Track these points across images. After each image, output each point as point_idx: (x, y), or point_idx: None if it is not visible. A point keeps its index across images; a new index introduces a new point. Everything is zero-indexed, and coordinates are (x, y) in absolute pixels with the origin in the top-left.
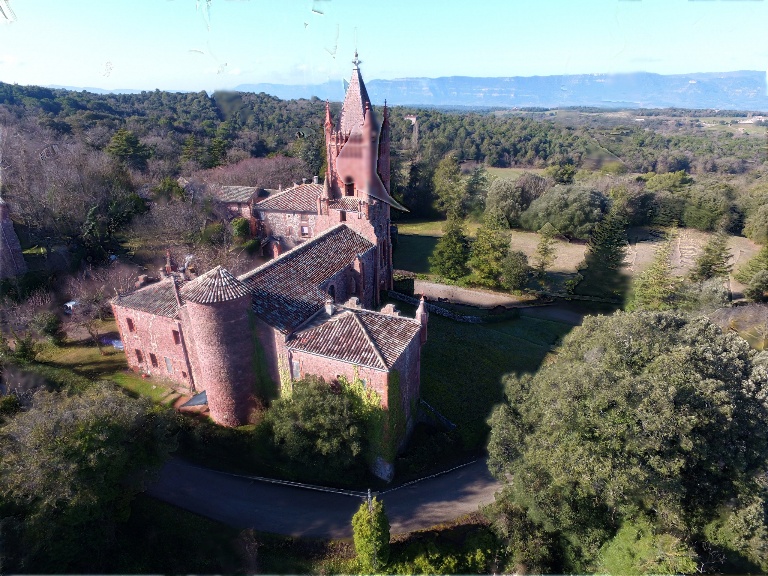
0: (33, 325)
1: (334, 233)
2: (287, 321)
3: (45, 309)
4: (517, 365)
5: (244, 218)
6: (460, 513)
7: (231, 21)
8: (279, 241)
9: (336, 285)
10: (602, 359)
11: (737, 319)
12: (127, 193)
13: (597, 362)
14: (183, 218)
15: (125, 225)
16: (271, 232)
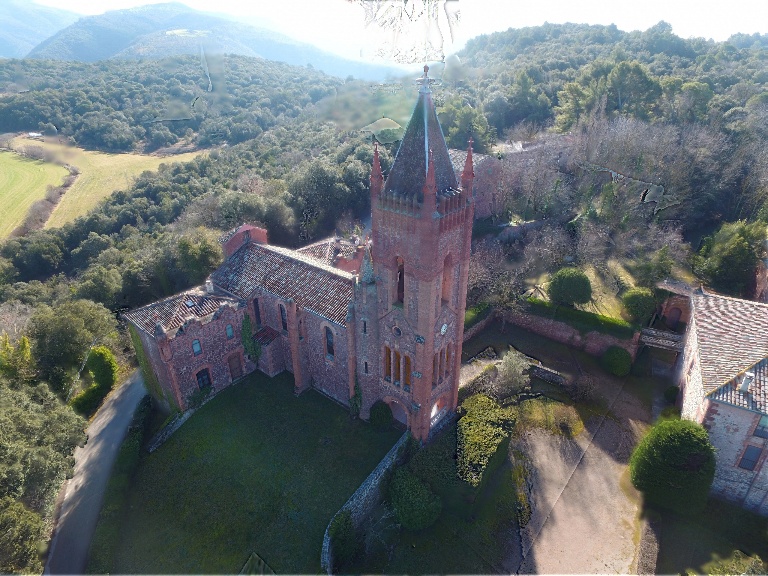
0: None
1: None
2: (218, 277)
3: None
4: None
5: (645, 292)
6: (88, 433)
7: None
8: (683, 360)
9: None
10: None
11: None
12: (640, 211)
13: None
14: (562, 245)
15: None
16: (687, 341)
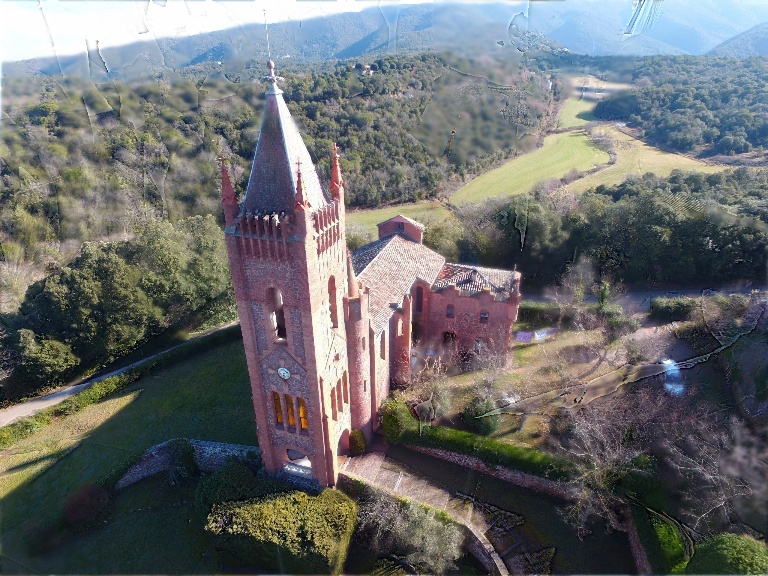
0: (620, 316)
1: None
2: None
3: (711, 375)
4: (156, 397)
5: None
6: None
7: (493, 3)
8: None
9: None
10: (188, 234)
11: None
12: None
13: (190, 236)
14: None
15: None
16: None
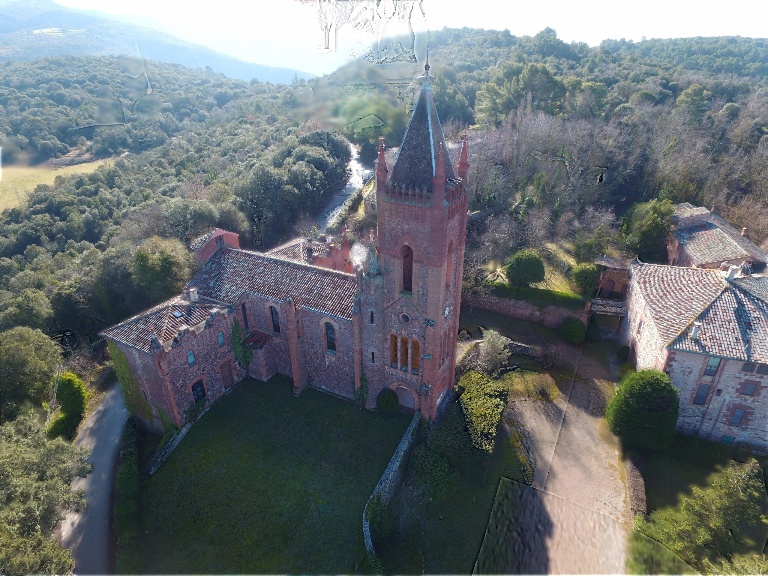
0: None
1: (348, 279)
2: (197, 285)
3: None
4: None
5: (591, 267)
6: None
7: None
8: (628, 322)
9: (281, 311)
10: None
11: None
12: (571, 197)
13: None
14: (514, 231)
15: (494, 217)
16: None
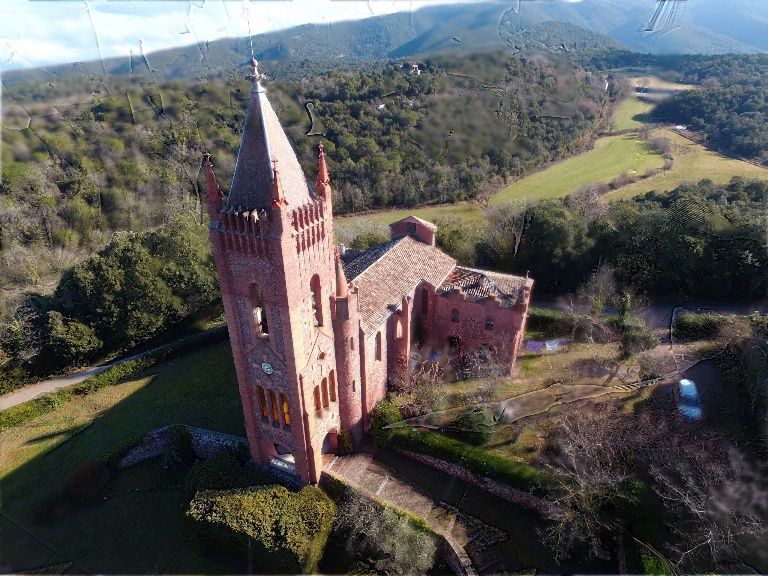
0: None
1: None
2: None
3: (735, 400)
4: (167, 383)
5: None
6: None
7: None
8: None
9: None
10: None
11: (9, 297)
12: None
13: None
14: None
15: None
16: None
